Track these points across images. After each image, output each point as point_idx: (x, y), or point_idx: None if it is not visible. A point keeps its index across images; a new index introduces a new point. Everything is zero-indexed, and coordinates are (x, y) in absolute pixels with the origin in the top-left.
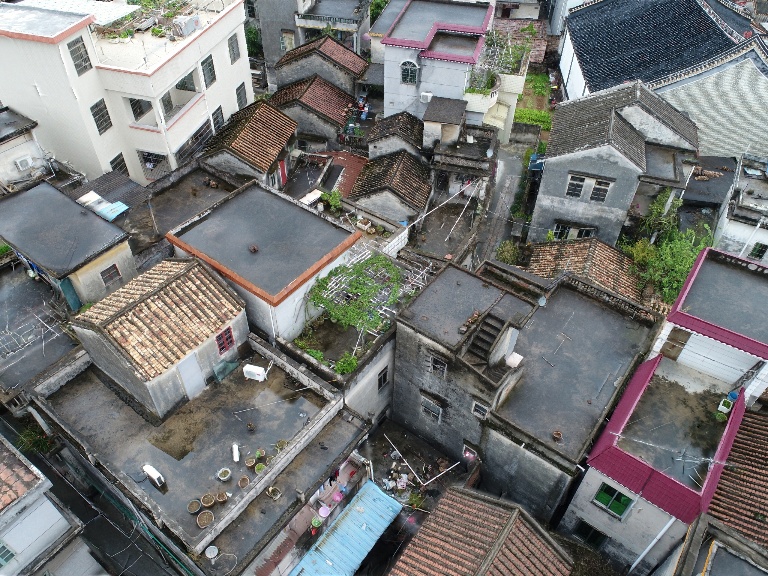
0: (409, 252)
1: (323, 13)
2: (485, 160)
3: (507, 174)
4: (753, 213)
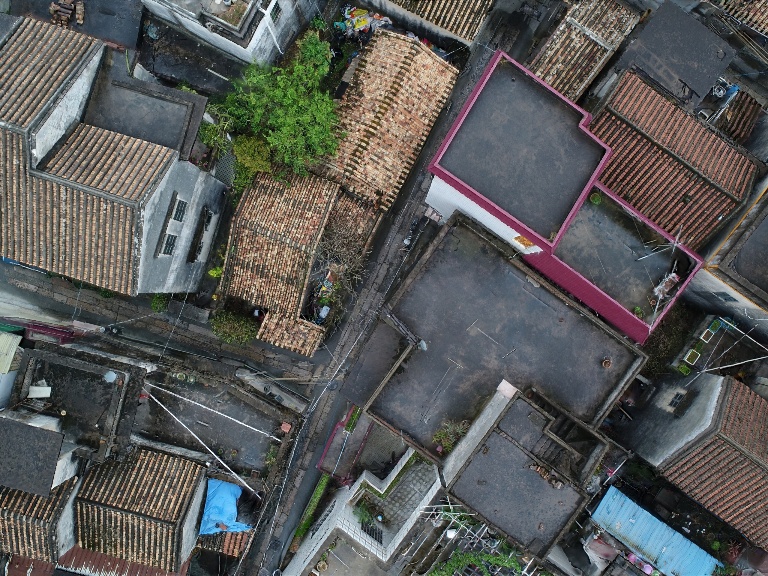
0: None
1: None
2: (123, 383)
3: (3, 284)
4: (250, 15)
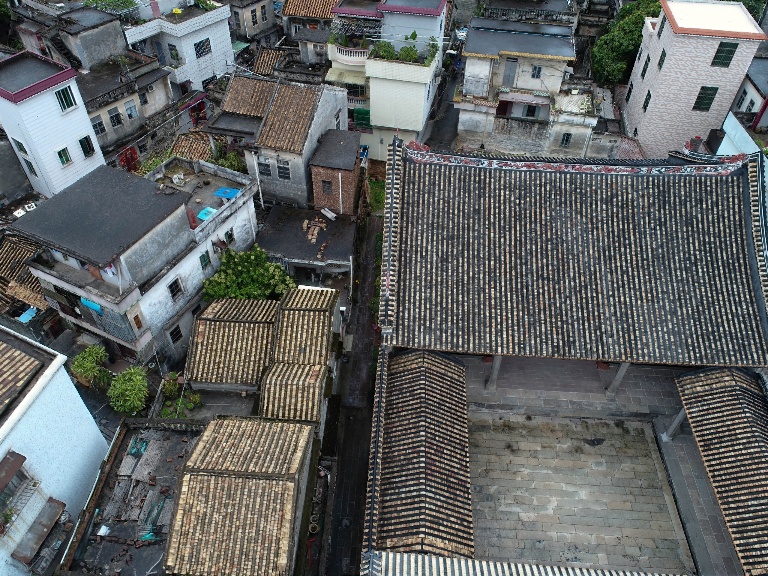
0: (225, 78)
1: (518, 4)
2: None
3: None
4: None
